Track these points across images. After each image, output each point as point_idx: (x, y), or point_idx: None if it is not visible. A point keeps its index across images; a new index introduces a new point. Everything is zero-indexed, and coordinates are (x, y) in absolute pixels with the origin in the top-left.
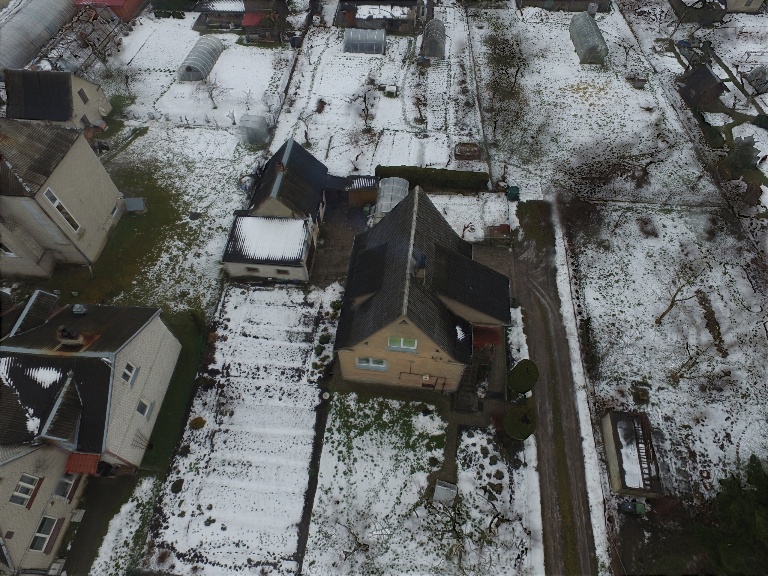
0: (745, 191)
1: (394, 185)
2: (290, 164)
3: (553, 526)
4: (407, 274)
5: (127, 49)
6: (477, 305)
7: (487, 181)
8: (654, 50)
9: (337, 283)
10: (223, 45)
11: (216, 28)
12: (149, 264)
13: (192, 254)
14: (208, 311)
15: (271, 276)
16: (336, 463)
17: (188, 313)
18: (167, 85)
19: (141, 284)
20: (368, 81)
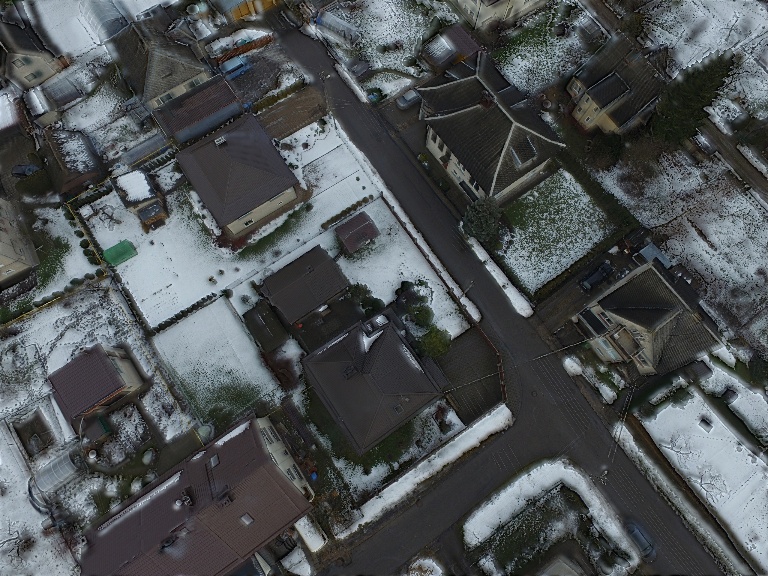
0: None
1: None
2: None
3: None
4: None
5: None
6: None
7: None
8: None
9: None
10: None
11: None
12: None
13: None
14: None
15: None
16: (767, 81)
17: None
18: None
19: None
20: None
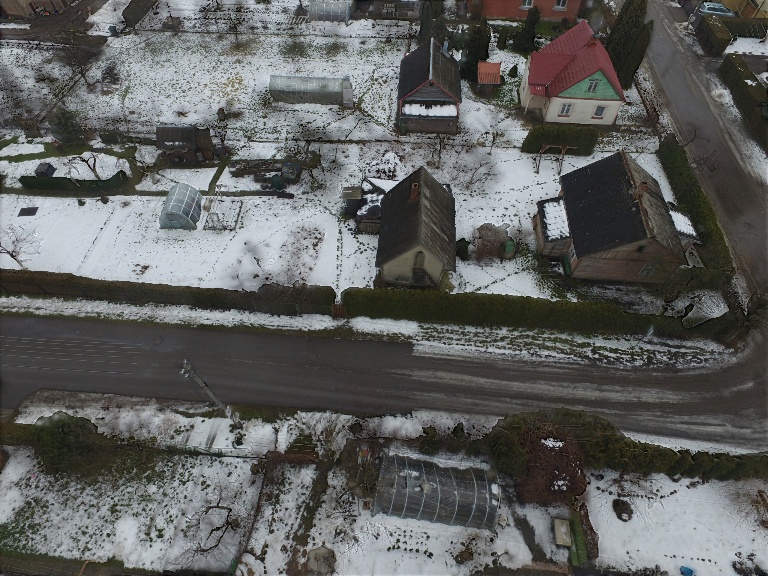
0: None
1: None
2: None
3: None
4: None
5: None
6: None
7: None
8: None
9: None
10: None
11: None
12: None
13: None
14: None
15: None
16: None
17: None
18: None
19: None
20: None
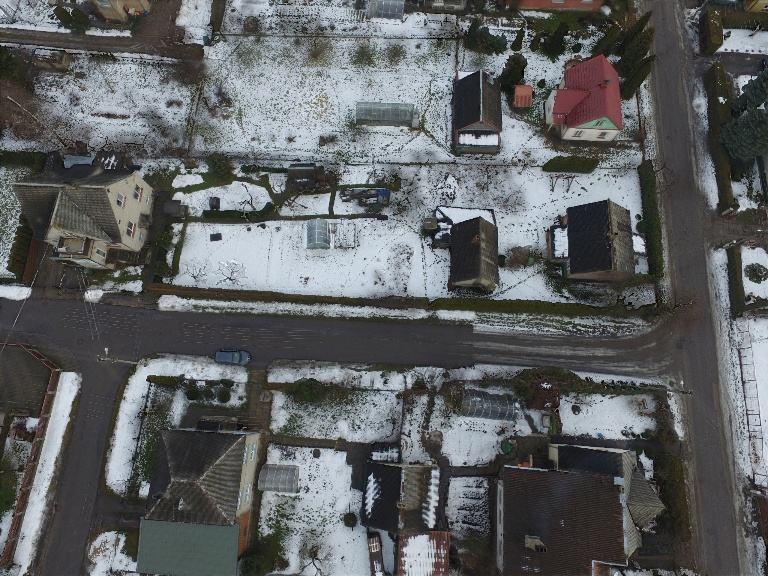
0: None
1: None
2: None
3: (36, 34)
4: None
5: None
6: None
7: None
8: None
9: None
10: None
11: None
12: None
13: None
14: None
15: None
16: None
17: None
18: None
19: None
20: None
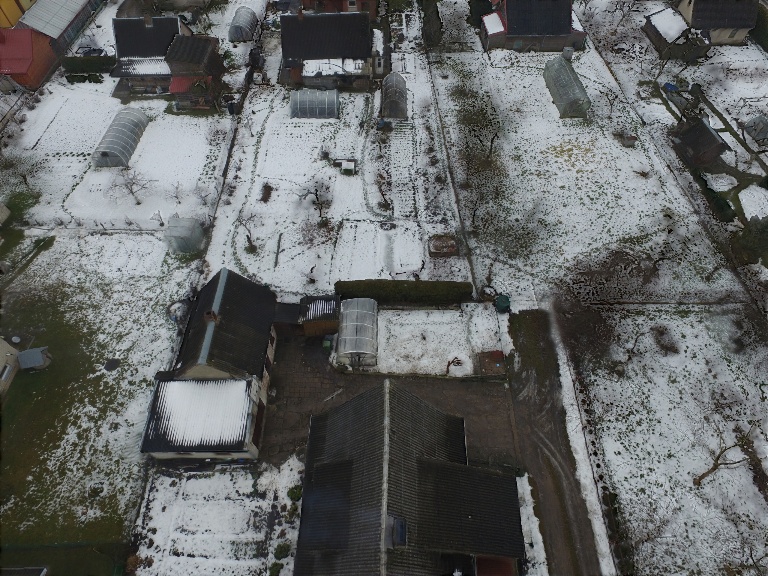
0: (767, 280)
1: (359, 310)
2: (224, 306)
3: None
4: (382, 554)
5: (32, 127)
6: (480, 545)
7: (471, 292)
8: (639, 96)
9: (295, 458)
10: (149, 115)
11: (140, 93)
12: (50, 446)
13: (107, 425)
14: (127, 517)
15: (209, 457)
16: None
17: (100, 523)
18: (80, 174)
19: (38, 480)
20: (321, 155)
